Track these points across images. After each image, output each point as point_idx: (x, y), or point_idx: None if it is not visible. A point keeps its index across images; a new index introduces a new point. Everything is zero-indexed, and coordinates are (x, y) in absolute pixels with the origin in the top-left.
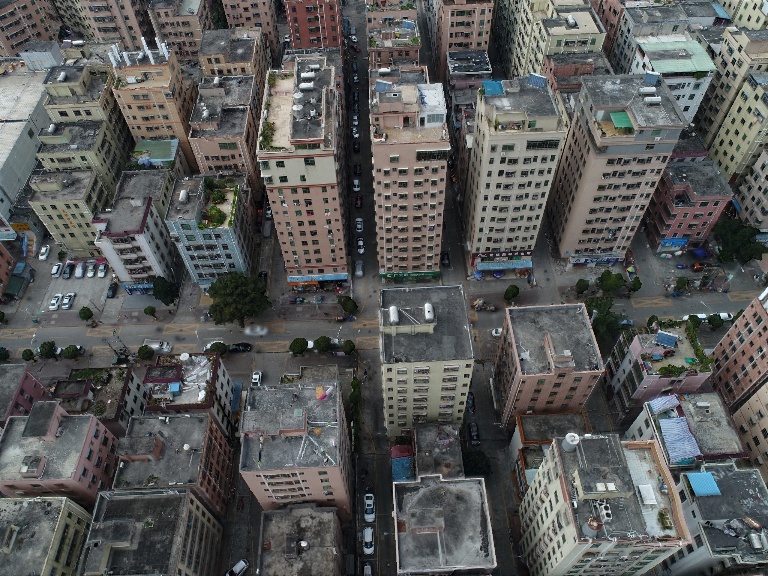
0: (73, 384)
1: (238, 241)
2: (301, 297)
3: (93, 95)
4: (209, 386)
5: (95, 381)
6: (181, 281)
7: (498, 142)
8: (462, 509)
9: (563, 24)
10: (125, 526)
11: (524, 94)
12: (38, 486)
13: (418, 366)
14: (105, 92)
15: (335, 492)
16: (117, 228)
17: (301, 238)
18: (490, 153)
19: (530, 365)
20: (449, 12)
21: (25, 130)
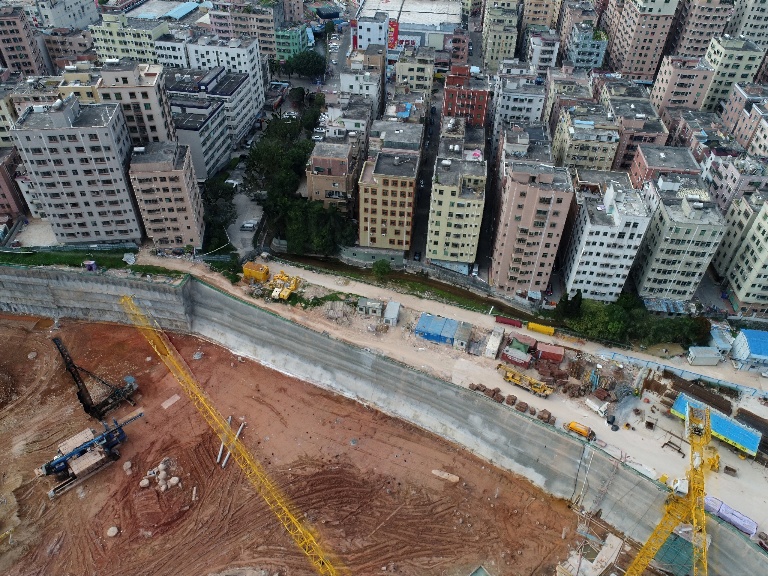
0: None
1: None
2: None
3: None
4: None
5: None
6: None
7: None
8: (766, 91)
9: None
10: None
11: None
12: None
13: (739, 54)
14: None
15: (698, 101)
16: None
17: (640, 51)
18: (753, 4)
19: None
20: None
21: None
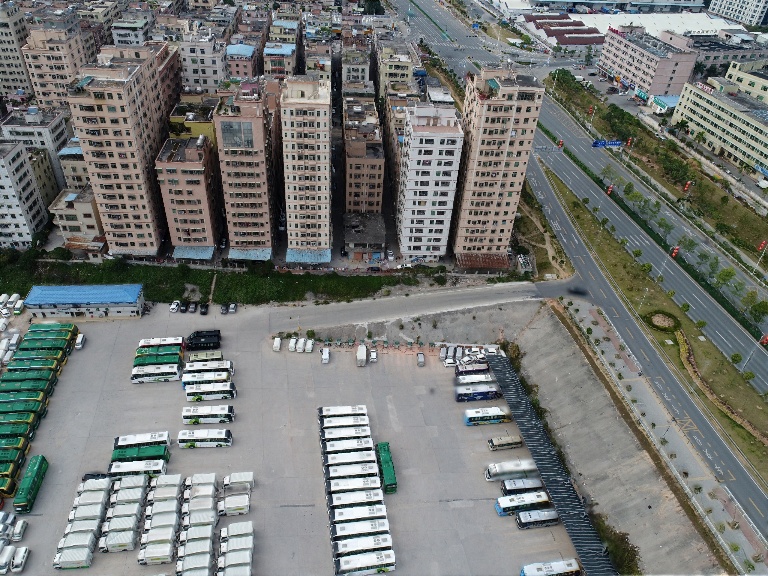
0: None
1: None
2: None
3: None
4: None
5: None
6: None
7: None
8: None
9: None
10: None
11: (1, 7)
12: None
13: None
14: None
15: None
16: None
17: None
18: None
19: None
20: None
21: None
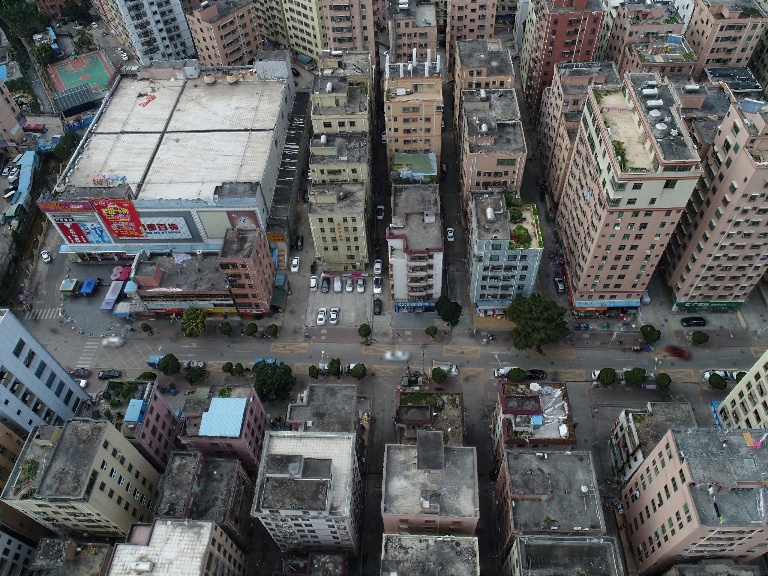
0: (413, 409)
1: None
2: (584, 323)
3: (356, 106)
4: (569, 420)
5: None
6: None
7: None
8: None
9: None
10: None
11: None
12: (430, 522)
13: None
14: (368, 103)
15: (760, 550)
16: (415, 245)
17: (613, 262)
18: None
19: None
20: (718, 26)
21: (274, 140)
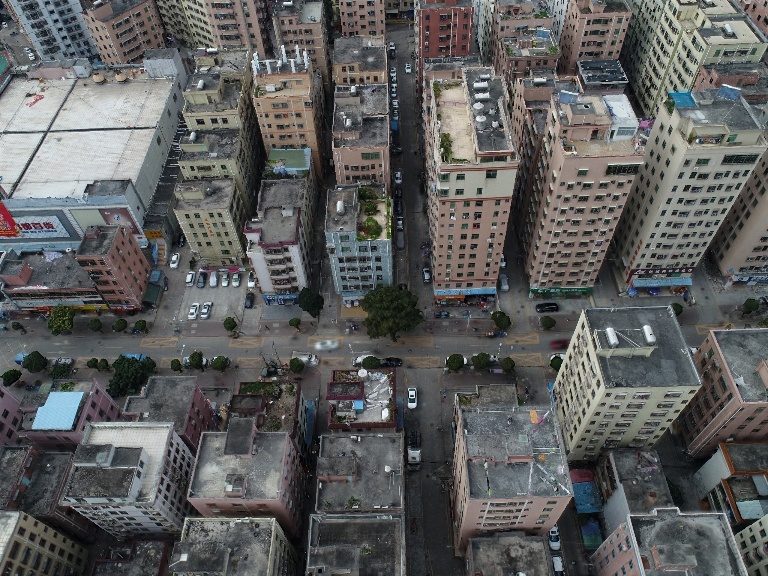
0: (248, 398)
1: (391, 253)
2: (445, 311)
3: None
4: (392, 404)
5: (266, 395)
6: (318, 292)
7: (694, 156)
8: (706, 546)
9: (719, 33)
10: (348, 552)
11: (717, 106)
12: (238, 505)
13: (640, 391)
14: (241, 100)
15: (548, 521)
16: (271, 238)
17: (459, 251)
18: (682, 167)
19: (747, 392)
20: (585, 20)
21: (155, 137)
